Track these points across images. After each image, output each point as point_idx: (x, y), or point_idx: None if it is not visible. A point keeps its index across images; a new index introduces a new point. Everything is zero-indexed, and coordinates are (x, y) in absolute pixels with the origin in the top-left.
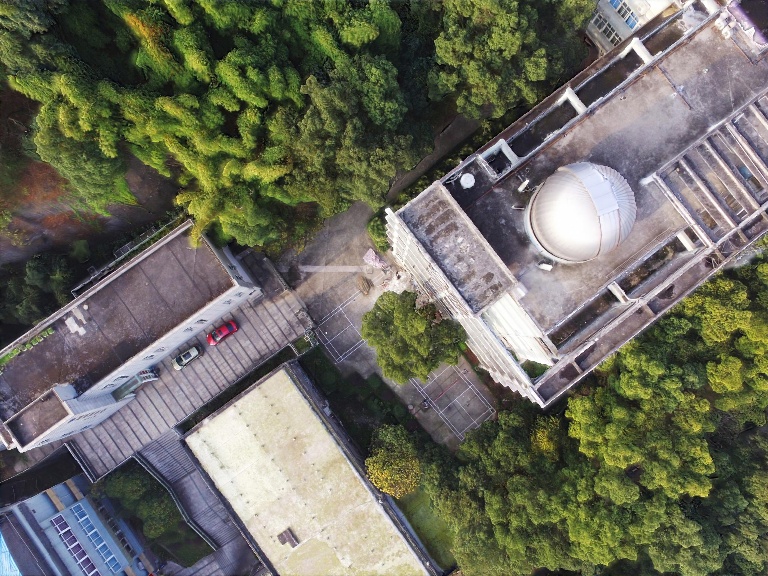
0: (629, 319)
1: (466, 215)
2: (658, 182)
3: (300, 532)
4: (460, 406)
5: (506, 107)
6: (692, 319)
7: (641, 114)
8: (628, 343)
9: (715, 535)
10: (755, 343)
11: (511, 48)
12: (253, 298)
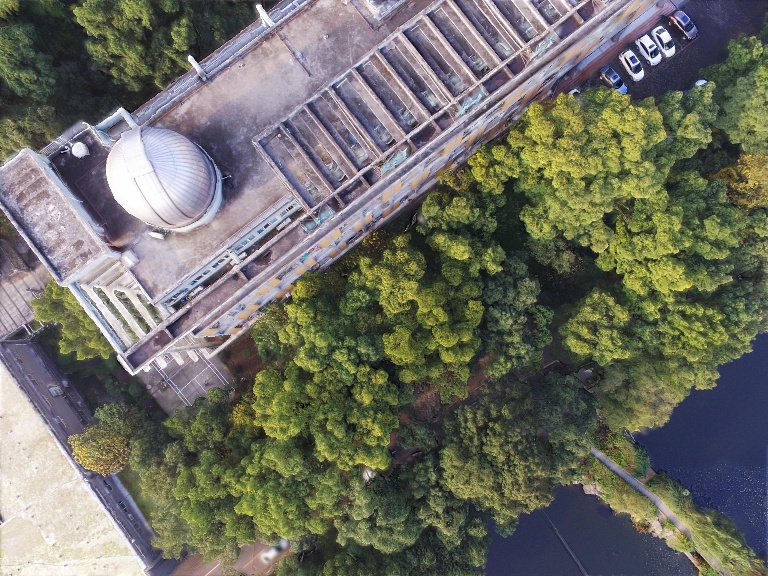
0: (225, 286)
1: (54, 182)
2: (258, 148)
3: (5, 511)
4: (199, 385)
5: (163, 79)
6: (374, 291)
7: (260, 81)
8: (305, 316)
9: (399, 508)
10: (428, 314)
11: (145, 17)
12: None
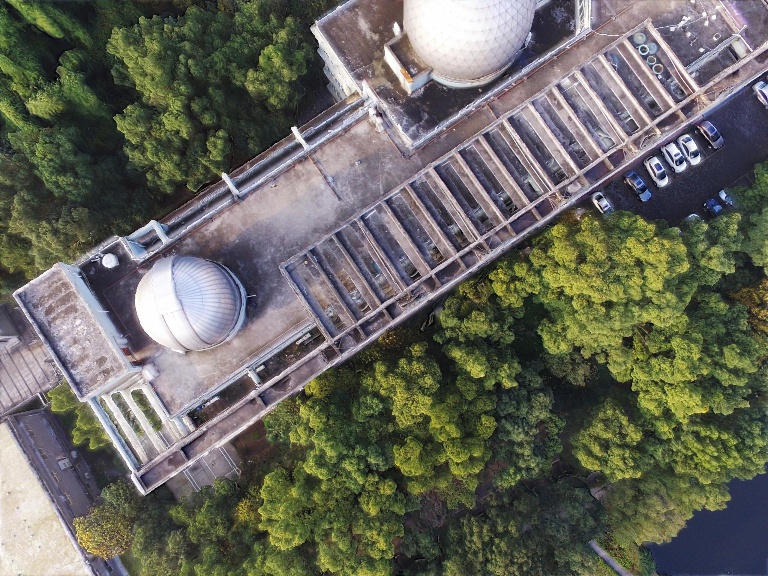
0: (242, 410)
1: (83, 298)
2: (284, 274)
3: None
4: (205, 465)
5: (195, 183)
6: (387, 399)
7: (290, 203)
8: (317, 421)
9: None
10: (440, 429)
11: (182, 129)
12: (10, 345)
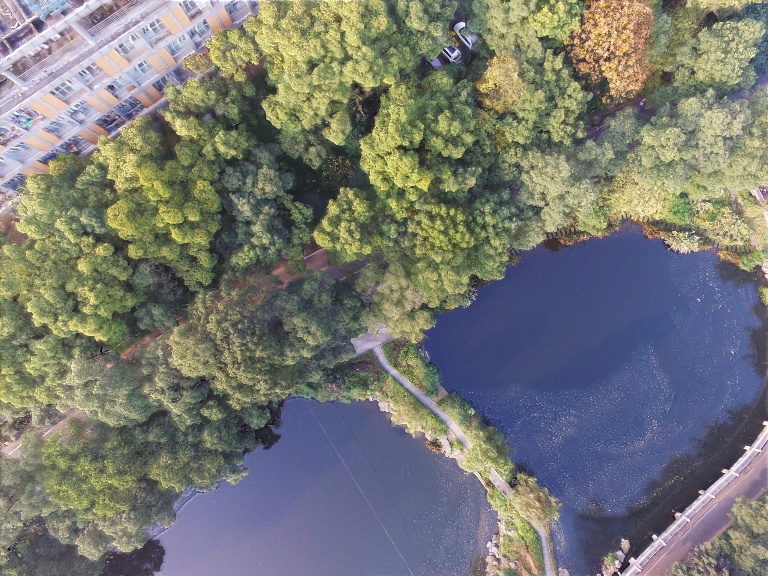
0: None
1: None
2: None
3: None
4: None
5: None
6: None
7: None
8: (35, 186)
9: (122, 380)
10: None
11: None
12: None
